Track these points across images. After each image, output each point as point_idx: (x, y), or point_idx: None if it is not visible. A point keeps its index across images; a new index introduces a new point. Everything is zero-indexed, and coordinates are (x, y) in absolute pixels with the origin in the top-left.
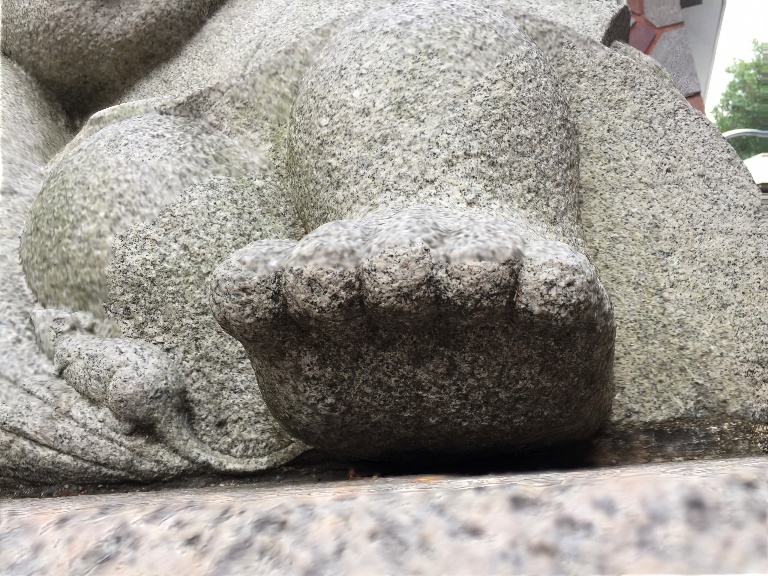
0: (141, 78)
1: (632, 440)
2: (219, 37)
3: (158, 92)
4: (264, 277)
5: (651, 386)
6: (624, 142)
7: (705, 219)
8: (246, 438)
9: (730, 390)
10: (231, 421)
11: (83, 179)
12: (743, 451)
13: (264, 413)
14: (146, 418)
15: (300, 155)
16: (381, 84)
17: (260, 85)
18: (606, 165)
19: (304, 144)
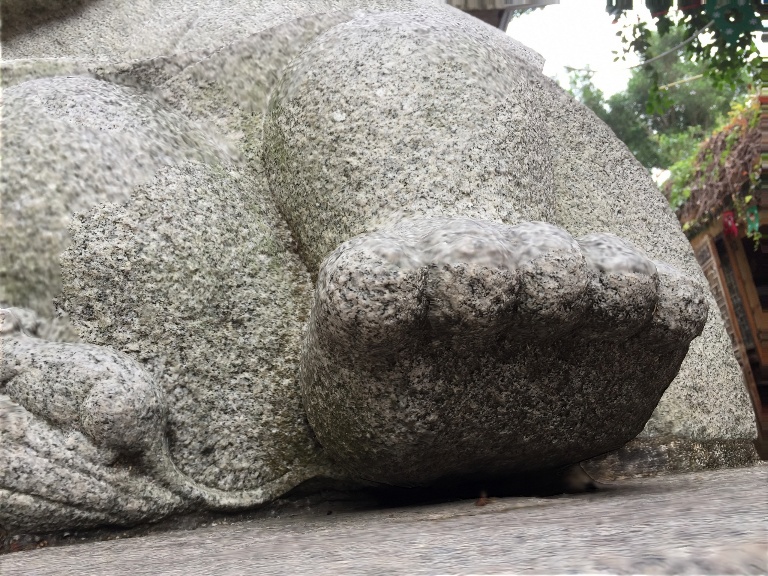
0: (22, 34)
1: (600, 459)
2: (134, 6)
3: (49, 54)
4: (411, 273)
5: None
6: (584, 181)
7: None
8: (236, 467)
9: (674, 412)
10: (220, 447)
11: (17, 140)
12: (686, 467)
13: (258, 437)
14: (135, 444)
15: (300, 149)
16: (407, 87)
17: (230, 67)
18: (571, 200)
19: (308, 138)
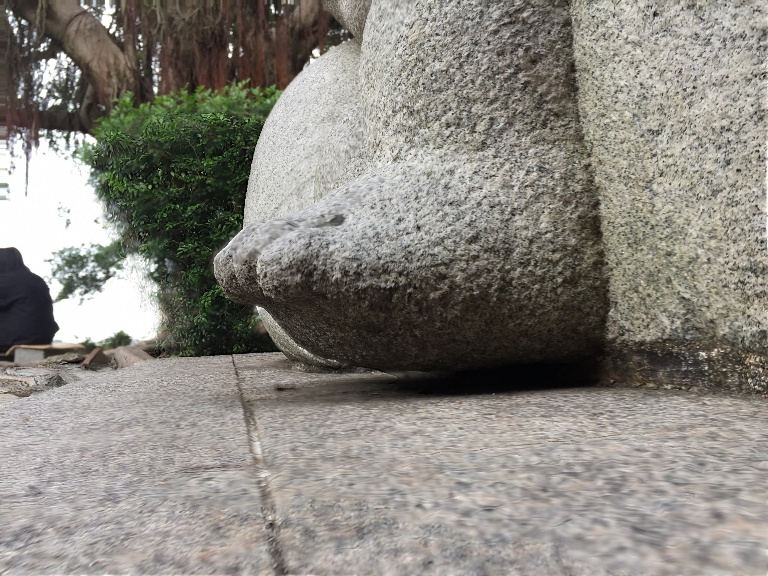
0: None
1: (626, 360)
2: None
3: None
4: None
5: (639, 301)
6: None
7: (696, 71)
8: None
9: (716, 307)
10: None
11: None
12: (732, 386)
13: None
14: None
15: None
16: (364, 59)
17: None
18: (595, 33)
19: None
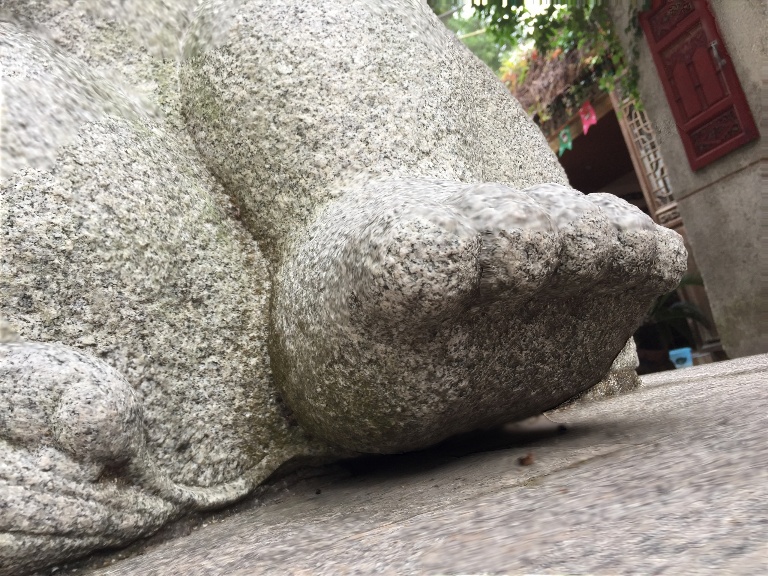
0: None
1: None
2: None
3: None
4: (469, 241)
5: None
6: (490, 138)
7: None
8: (215, 459)
9: None
10: (196, 441)
11: None
12: (590, 397)
13: (232, 424)
14: (122, 452)
15: (239, 104)
16: (355, 39)
17: (132, 4)
18: None
19: (248, 91)
